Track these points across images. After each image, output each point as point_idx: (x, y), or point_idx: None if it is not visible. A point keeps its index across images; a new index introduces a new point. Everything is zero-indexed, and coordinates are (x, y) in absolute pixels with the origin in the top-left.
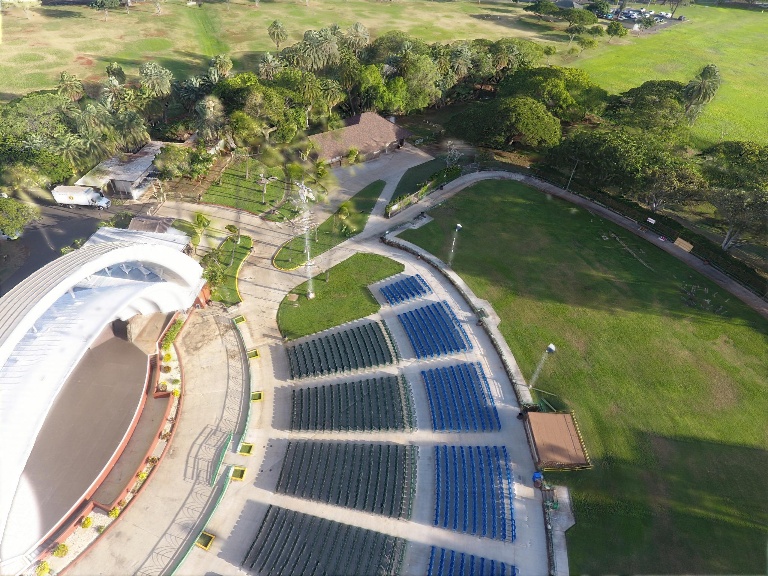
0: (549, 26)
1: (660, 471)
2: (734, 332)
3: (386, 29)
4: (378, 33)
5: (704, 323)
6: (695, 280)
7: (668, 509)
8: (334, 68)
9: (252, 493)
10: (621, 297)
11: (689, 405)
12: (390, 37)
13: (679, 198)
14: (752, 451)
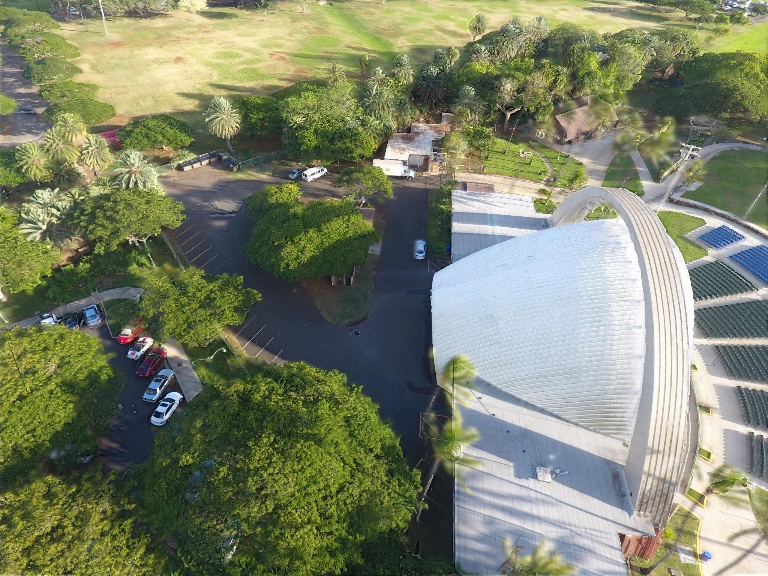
0: (663, 16)
1: None
2: None
3: None
4: None
5: None
6: None
7: None
8: None
9: (713, 380)
10: None
11: None
12: (566, 29)
13: None
14: None
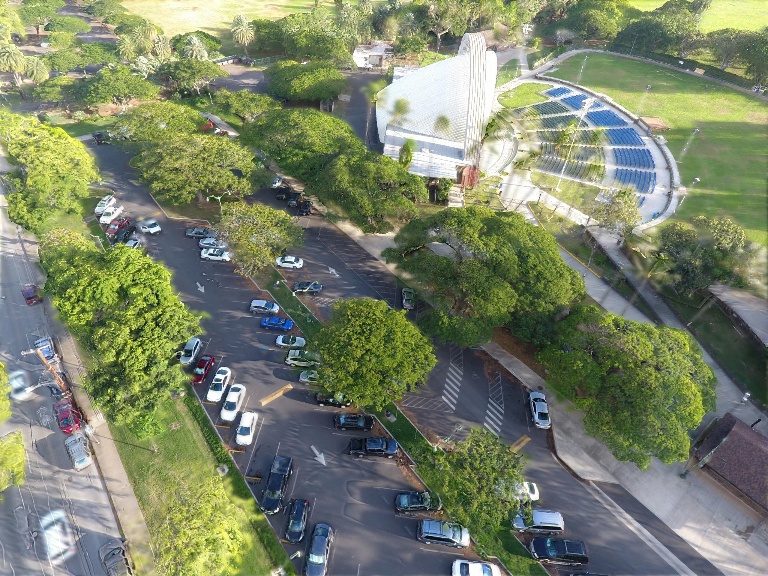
0: None
1: (700, 128)
2: (728, 96)
3: None
4: None
5: (714, 95)
6: (707, 83)
7: (705, 136)
8: None
9: (530, 142)
10: (671, 89)
11: (710, 114)
12: None
13: (697, 46)
14: (738, 122)
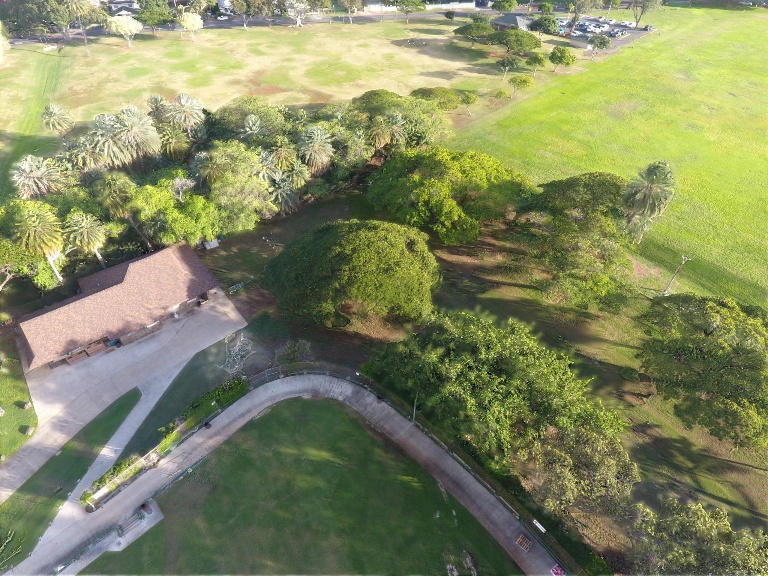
0: (484, 51)
1: None
2: None
3: (278, 71)
4: (264, 78)
5: None
6: None
7: None
8: (155, 157)
9: None
10: None
11: None
12: (234, 107)
13: None
14: None
